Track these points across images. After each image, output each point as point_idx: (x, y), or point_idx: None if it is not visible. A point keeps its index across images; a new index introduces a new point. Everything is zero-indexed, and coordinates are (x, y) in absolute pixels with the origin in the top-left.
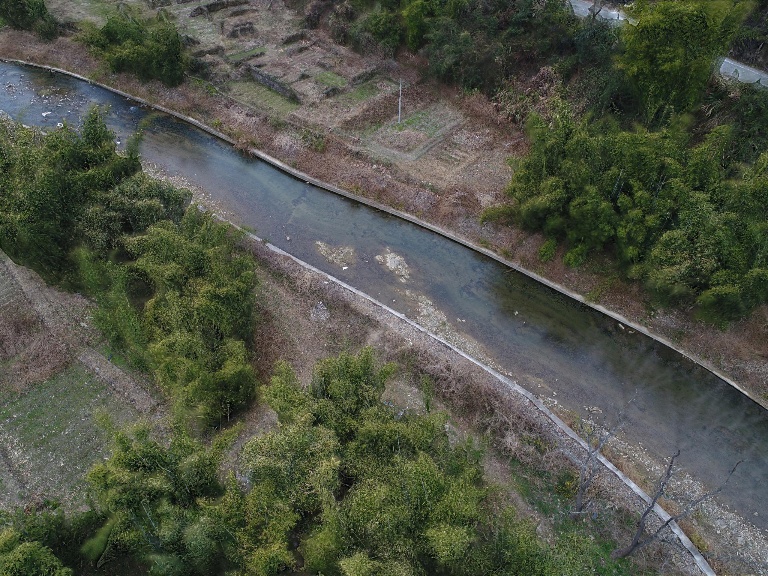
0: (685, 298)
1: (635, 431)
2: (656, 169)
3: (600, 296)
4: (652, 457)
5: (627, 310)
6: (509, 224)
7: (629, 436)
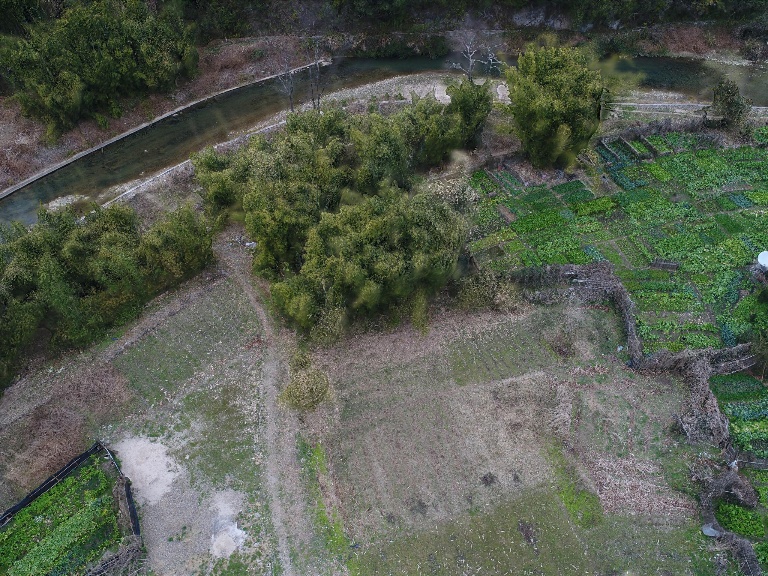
0: (176, 76)
1: (249, 123)
2: (99, 24)
3: (149, 115)
4: (265, 121)
5: (165, 108)
6: (60, 135)
7: (251, 125)
